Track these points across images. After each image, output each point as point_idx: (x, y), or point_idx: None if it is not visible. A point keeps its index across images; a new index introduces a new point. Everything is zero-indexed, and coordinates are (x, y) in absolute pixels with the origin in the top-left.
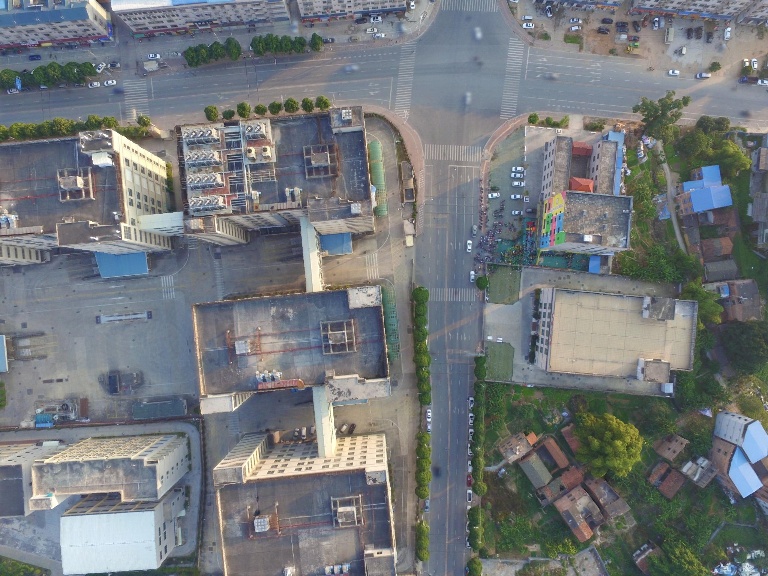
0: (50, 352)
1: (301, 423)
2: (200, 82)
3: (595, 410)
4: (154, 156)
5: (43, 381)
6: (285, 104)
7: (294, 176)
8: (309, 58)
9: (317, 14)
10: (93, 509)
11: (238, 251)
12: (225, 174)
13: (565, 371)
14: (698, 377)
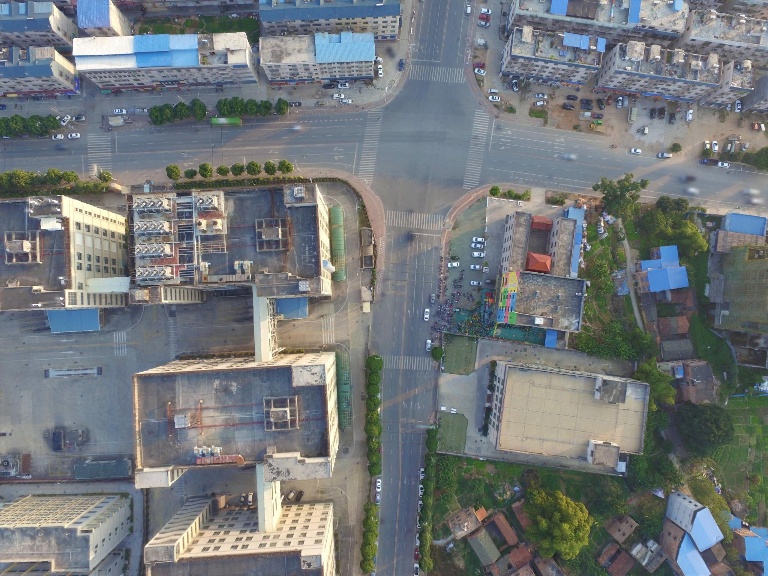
0: None
1: (248, 488)
2: (165, 139)
3: (547, 485)
4: (111, 213)
5: None
6: (247, 167)
7: (245, 248)
8: (275, 120)
9: (284, 79)
10: (25, 574)
11: (193, 310)
12: (175, 244)
13: (515, 450)
14: (652, 456)
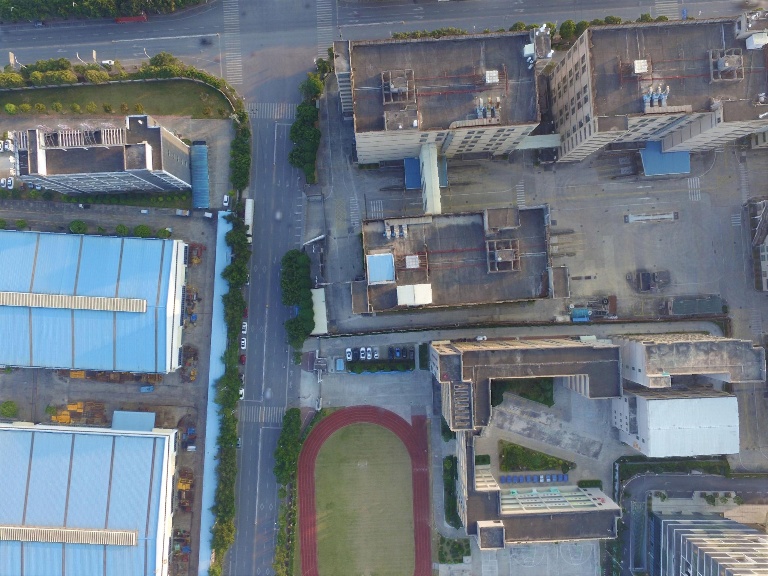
0: (579, 250)
1: None
2: None
3: None
4: None
5: (572, 278)
6: None
7: None
8: None
9: None
10: (666, 396)
11: (763, 155)
12: None
13: None
14: None
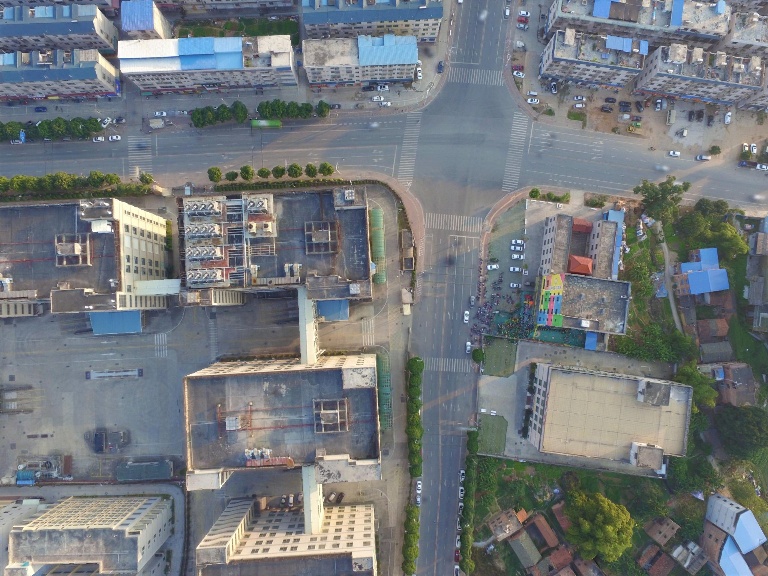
0: (37, 406)
1: (289, 490)
2: (205, 141)
3: (587, 487)
4: (154, 216)
5: (27, 436)
6: (289, 169)
7: (294, 251)
8: (315, 122)
9: (325, 81)
10: (70, 575)
11: (234, 312)
12: (225, 247)
13: (558, 452)
14: (691, 458)
